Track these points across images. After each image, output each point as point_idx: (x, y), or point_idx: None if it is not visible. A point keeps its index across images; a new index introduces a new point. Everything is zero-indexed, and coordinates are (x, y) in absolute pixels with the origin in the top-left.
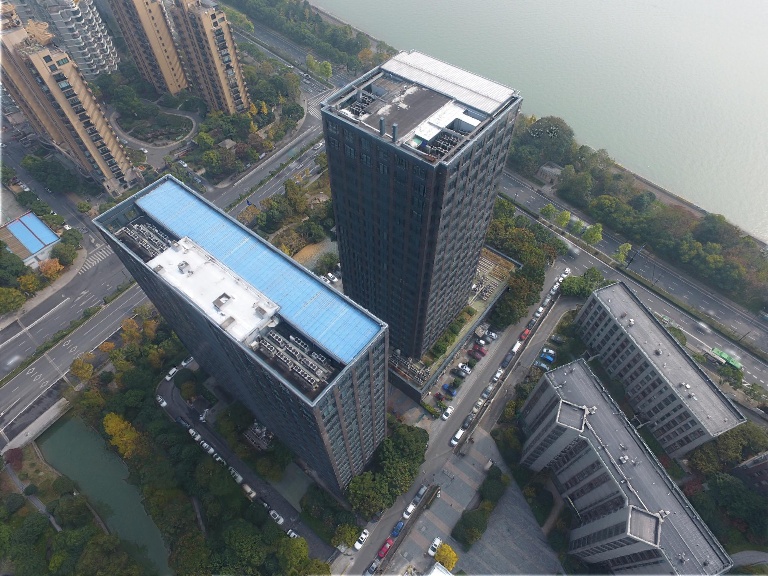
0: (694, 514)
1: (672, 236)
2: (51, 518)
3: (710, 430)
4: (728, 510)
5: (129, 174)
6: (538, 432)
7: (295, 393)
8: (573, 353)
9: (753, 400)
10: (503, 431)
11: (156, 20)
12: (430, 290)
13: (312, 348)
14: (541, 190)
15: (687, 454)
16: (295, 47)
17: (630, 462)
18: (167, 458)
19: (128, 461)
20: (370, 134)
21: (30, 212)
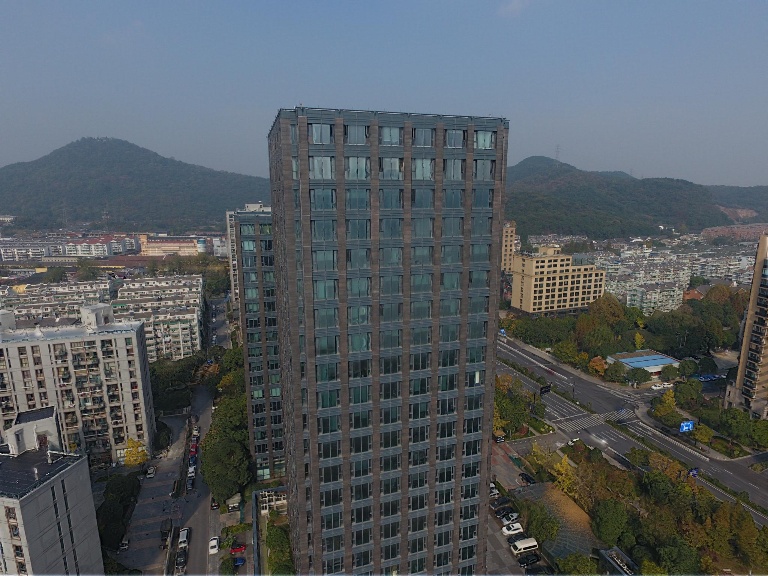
0: None
1: None
2: None
3: None
4: None
5: (762, 406)
6: None
7: None
8: None
9: None
10: None
11: None
12: None
13: None
14: None
15: None
16: None
17: None
18: None
19: None
20: None
21: (680, 362)
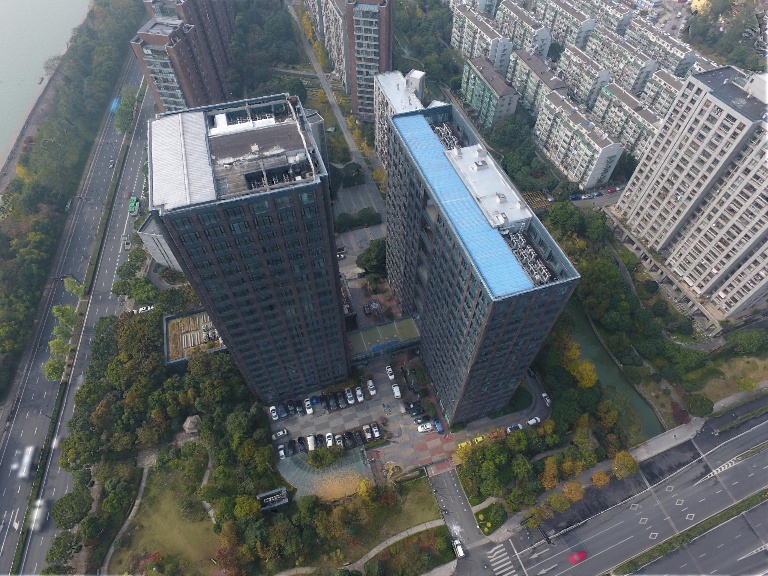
0: None
1: None
2: (638, 355)
3: None
4: None
5: None
6: None
7: None
8: None
9: None
10: None
11: None
12: None
13: None
14: (6, 418)
15: None
16: None
17: None
18: None
19: None
20: None
21: None
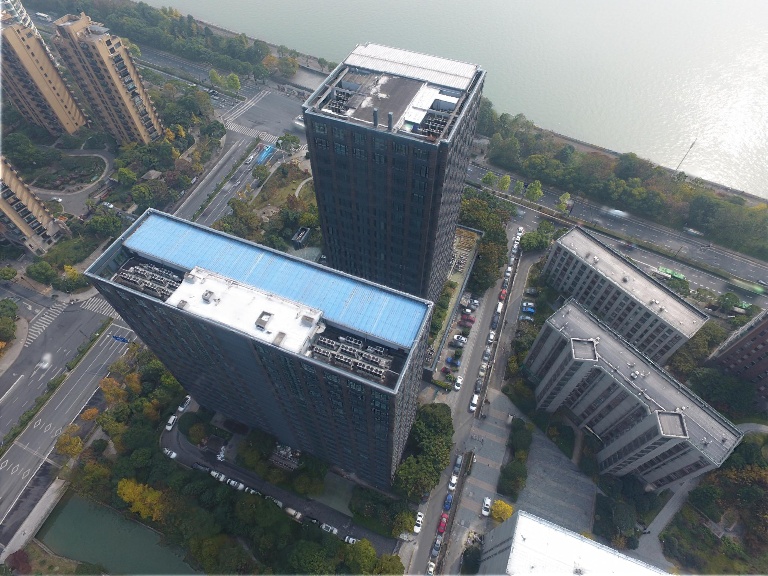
0: (702, 403)
1: (599, 179)
2: None
3: (686, 333)
4: (711, 397)
5: (51, 227)
6: (551, 375)
7: (374, 386)
8: (549, 300)
9: (701, 302)
10: (512, 385)
11: (37, 56)
12: (431, 269)
13: (365, 343)
14: (475, 161)
15: (668, 360)
16: (191, 64)
17: (640, 376)
18: (201, 506)
19: (153, 524)
20: (364, 127)
21: None
